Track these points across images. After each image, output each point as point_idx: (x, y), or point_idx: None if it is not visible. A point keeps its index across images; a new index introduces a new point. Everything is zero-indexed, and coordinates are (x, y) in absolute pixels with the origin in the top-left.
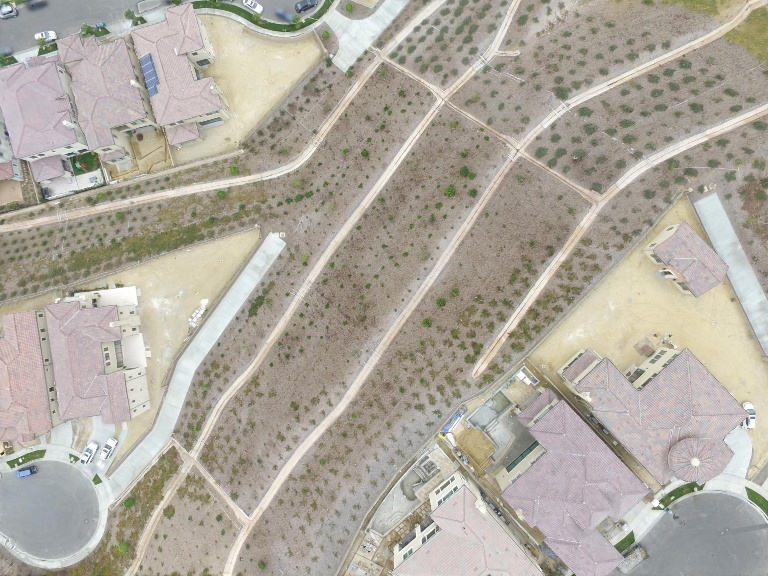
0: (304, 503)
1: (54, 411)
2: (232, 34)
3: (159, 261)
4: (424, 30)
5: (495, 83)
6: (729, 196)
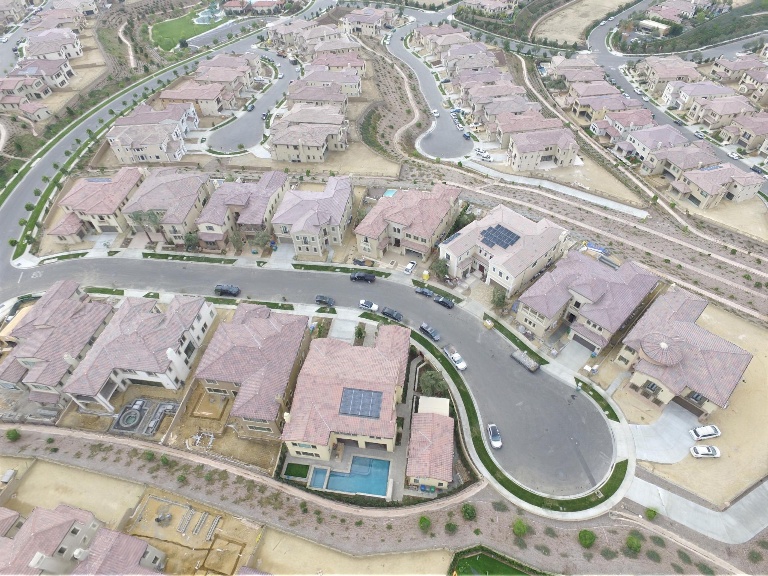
0: (502, 202)
1: None
2: (758, 209)
3: (604, 172)
4: None
5: None
6: None
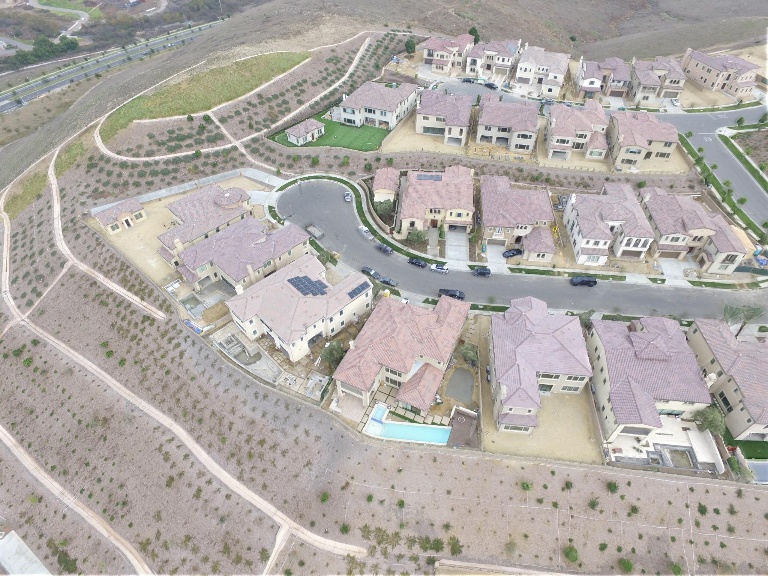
0: (261, 455)
1: None
2: None
3: None
4: None
5: None
6: (95, 204)
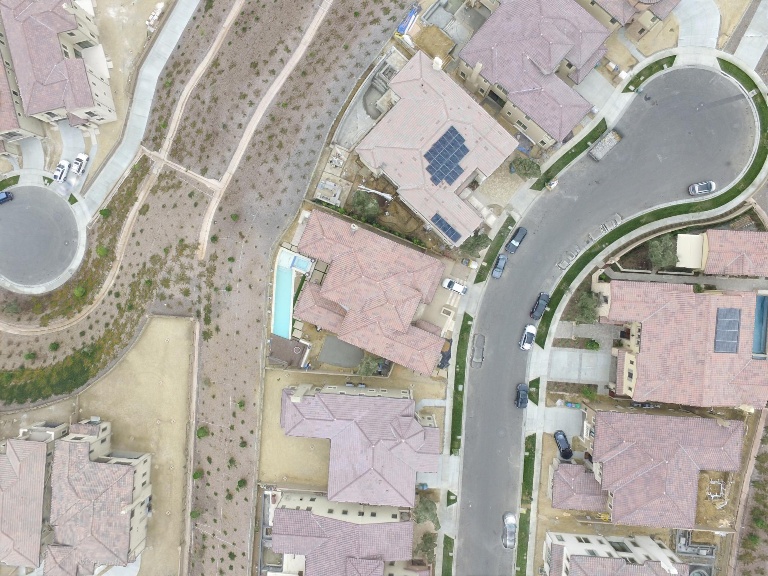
0: (270, 148)
1: (20, 115)
2: None
3: None
4: None
5: None
6: None
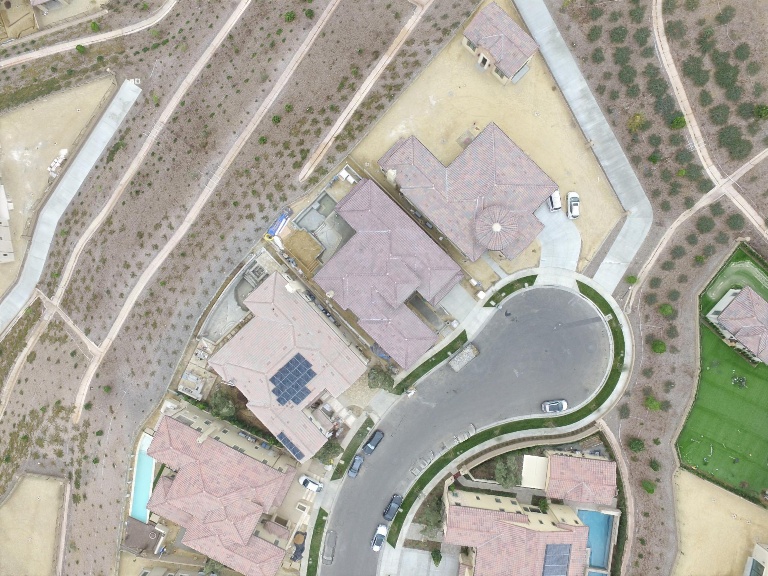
0: (146, 324)
1: None
2: None
3: (17, 113)
4: None
5: None
6: None
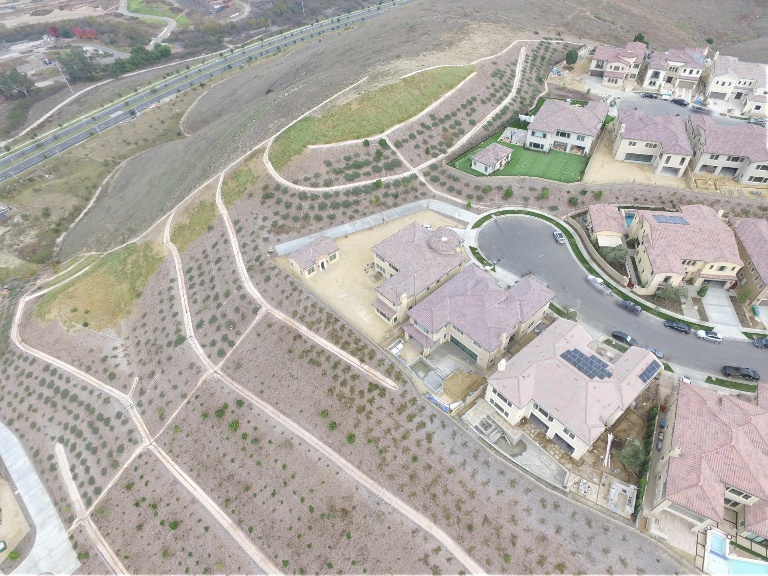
0: None
1: None
2: None
3: None
4: (79, 469)
5: (154, 395)
6: (278, 240)
